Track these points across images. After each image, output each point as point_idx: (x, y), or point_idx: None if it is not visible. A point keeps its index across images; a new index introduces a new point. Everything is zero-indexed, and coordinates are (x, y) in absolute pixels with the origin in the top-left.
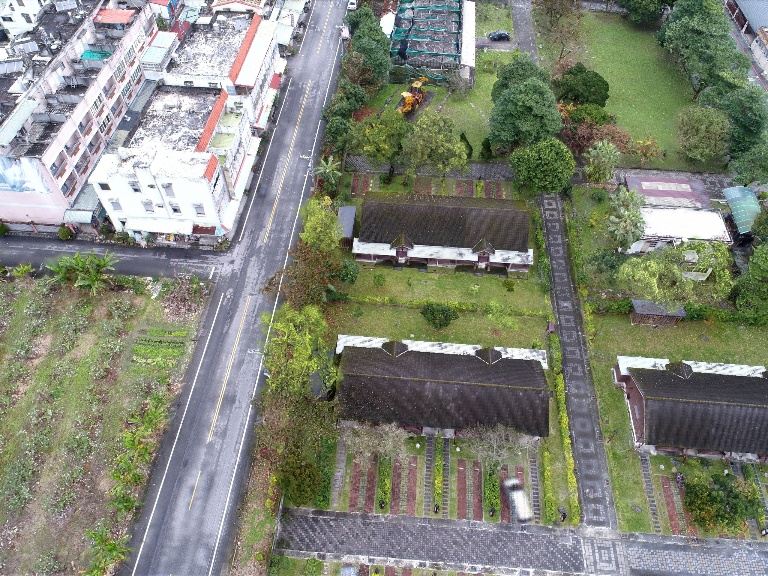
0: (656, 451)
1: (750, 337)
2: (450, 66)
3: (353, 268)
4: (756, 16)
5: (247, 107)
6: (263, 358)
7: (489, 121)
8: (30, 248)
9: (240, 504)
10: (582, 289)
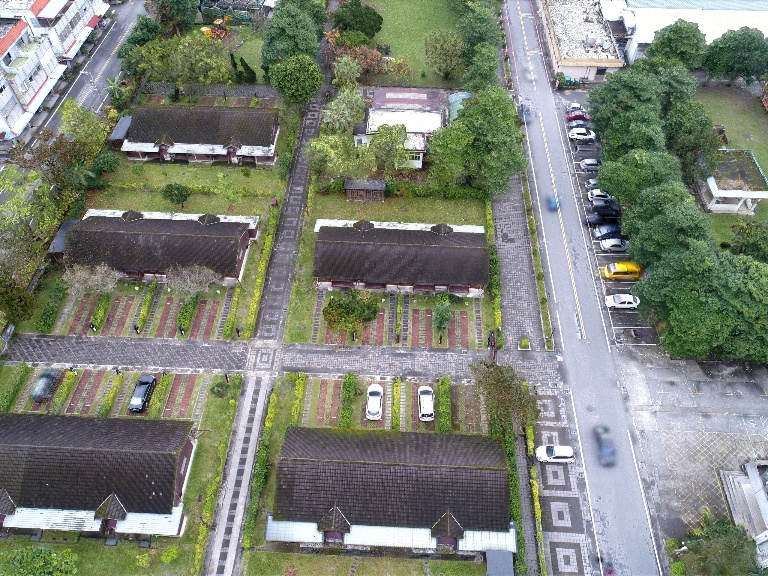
0: (332, 287)
1: (443, 208)
2: None
3: (112, 159)
4: None
5: (53, 38)
6: None
7: None
8: None
9: None
10: (312, 175)
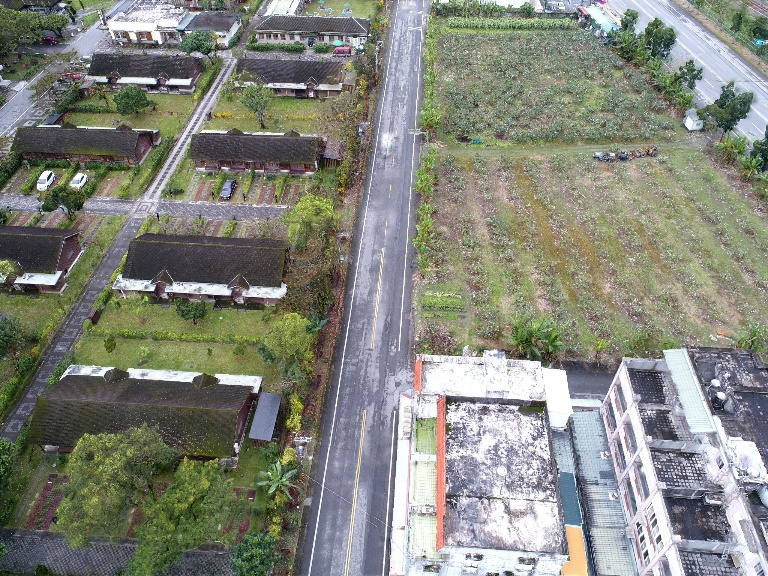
0: None
1: None
2: None
3: (263, 341)
4: None
5: None
6: (331, 202)
7: None
8: None
9: (357, 222)
10: None
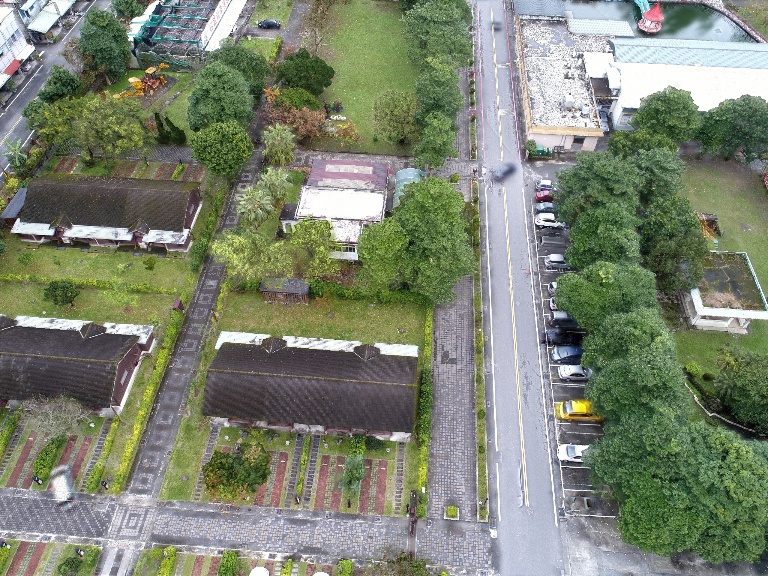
0: (229, 423)
1: (376, 314)
2: (196, 53)
3: None
4: (522, 4)
5: None
6: None
7: (190, 105)
8: None
9: None
10: (229, 268)
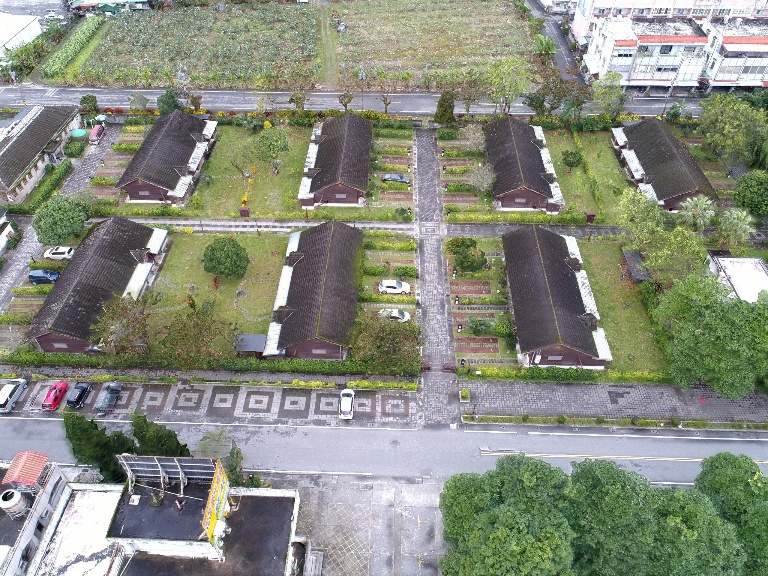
0: None
1: (641, 338)
2: None
3: (593, 122)
4: None
5: None
6: None
7: None
8: (559, 43)
9: None
10: None
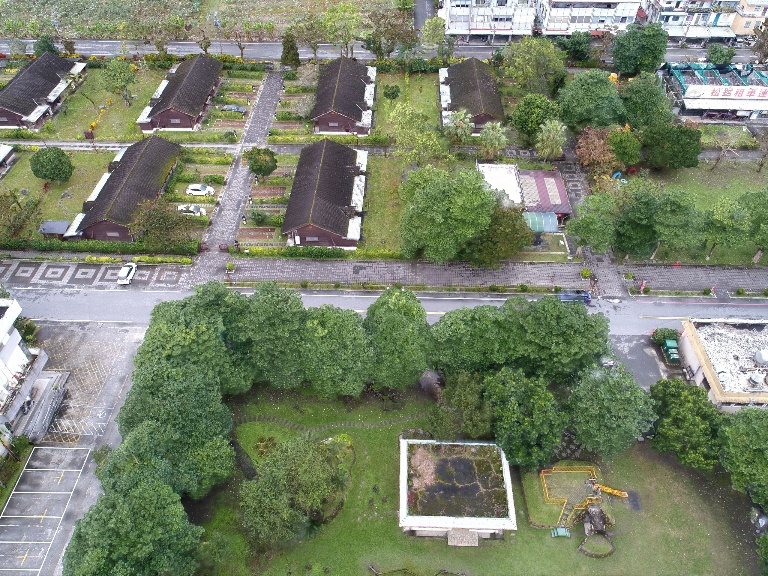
0: None
1: None
2: None
3: (420, 62)
4: None
5: None
6: None
7: None
8: (427, 1)
9: None
10: None
